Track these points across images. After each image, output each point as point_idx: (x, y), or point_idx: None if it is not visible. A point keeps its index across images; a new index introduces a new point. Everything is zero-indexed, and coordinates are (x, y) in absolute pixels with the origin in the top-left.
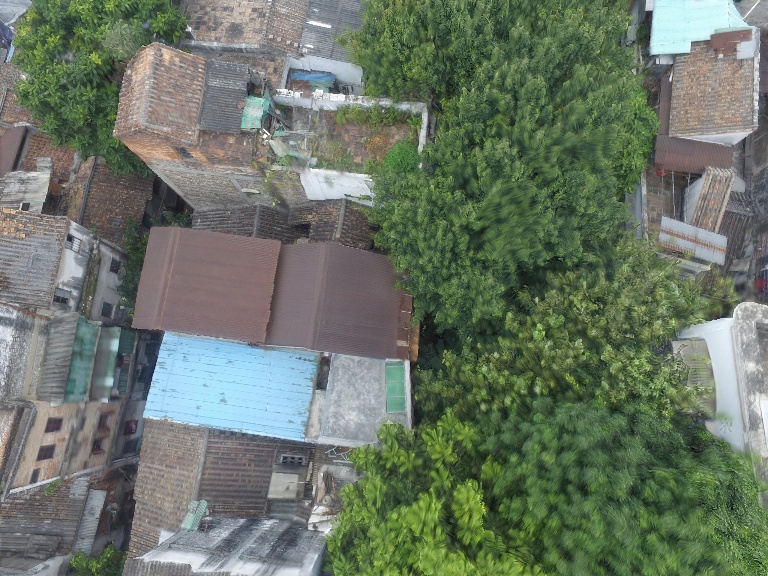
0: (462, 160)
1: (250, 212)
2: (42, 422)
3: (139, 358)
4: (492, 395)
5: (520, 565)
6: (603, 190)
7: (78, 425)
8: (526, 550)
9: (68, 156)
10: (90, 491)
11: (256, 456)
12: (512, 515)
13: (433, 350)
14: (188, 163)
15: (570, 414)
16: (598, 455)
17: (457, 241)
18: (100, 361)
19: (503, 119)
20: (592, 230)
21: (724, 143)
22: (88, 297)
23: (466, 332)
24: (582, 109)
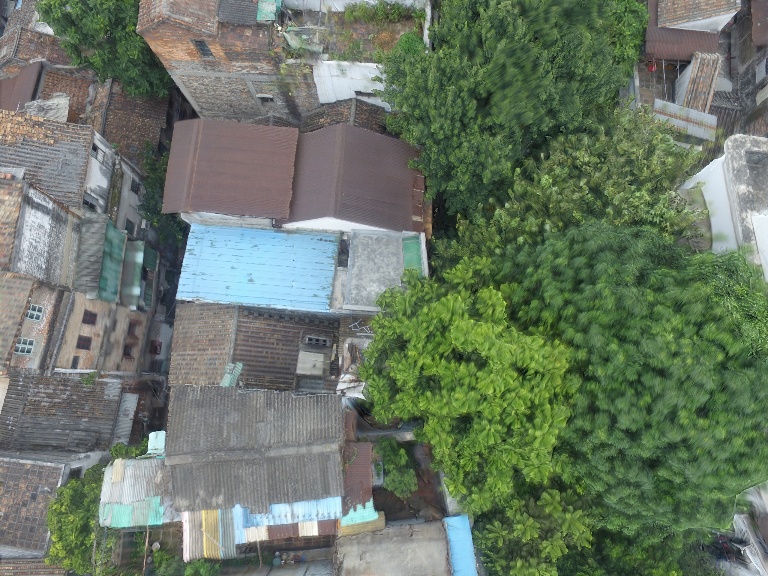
0: (467, 30)
1: (264, 123)
2: (79, 312)
3: (161, 280)
4: (505, 244)
5: (541, 339)
6: (599, 57)
7: (111, 324)
8: (545, 336)
9: (82, 92)
10: (123, 394)
11: (283, 336)
12: (531, 314)
13: (445, 236)
14: (206, 63)
15: (579, 229)
16: (606, 256)
17: (465, 109)
18: (127, 271)
19: None
20: (590, 98)
21: (710, 30)
22: (113, 208)
23: (476, 210)
24: None
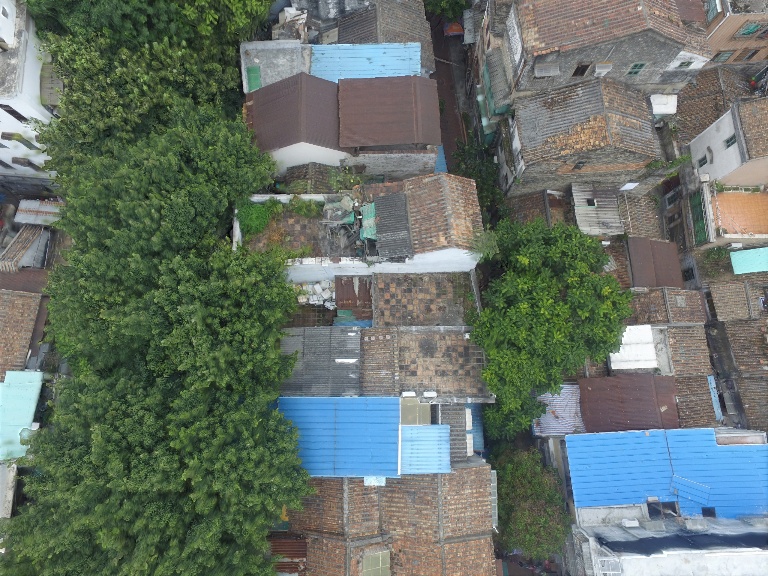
0: None
1: None
2: None
3: None
4: None
5: None
6: None
7: None
8: None
9: None
10: None
11: None
12: None
13: None
14: None
15: (122, 11)
16: None
17: None
18: None
19: (155, 194)
20: None
21: None
22: (506, 136)
23: None
24: (92, 191)
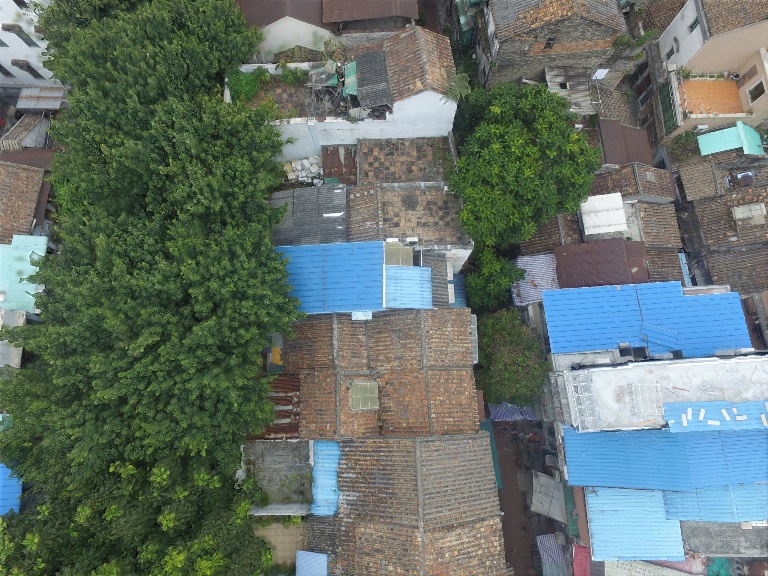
0: None
1: None
2: None
3: None
4: None
5: None
6: None
7: None
8: None
9: None
10: None
11: None
12: None
13: None
14: None
15: None
16: None
17: None
18: None
19: None
20: None
21: None
22: (482, 26)
23: None
24: None
